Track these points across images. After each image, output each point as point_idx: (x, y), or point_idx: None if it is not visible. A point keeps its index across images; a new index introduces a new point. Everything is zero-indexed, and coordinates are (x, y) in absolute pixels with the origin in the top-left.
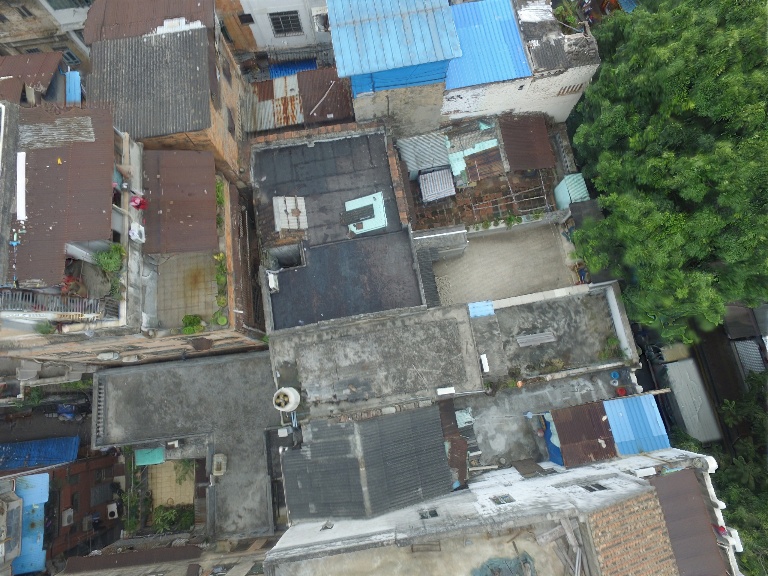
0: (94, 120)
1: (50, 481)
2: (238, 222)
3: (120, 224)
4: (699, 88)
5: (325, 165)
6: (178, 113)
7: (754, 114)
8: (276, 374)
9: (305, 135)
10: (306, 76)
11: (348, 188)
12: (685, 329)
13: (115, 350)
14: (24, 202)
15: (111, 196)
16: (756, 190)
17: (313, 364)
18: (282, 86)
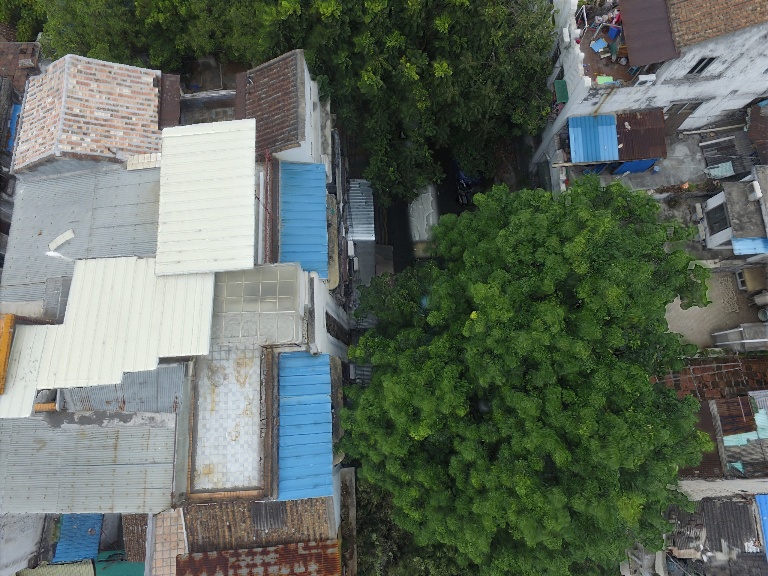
0: None
1: None
2: None
3: None
4: None
5: None
6: None
7: None
8: None
9: None
10: None
11: None
12: None
13: None
14: None
15: None
16: None
17: None
18: None
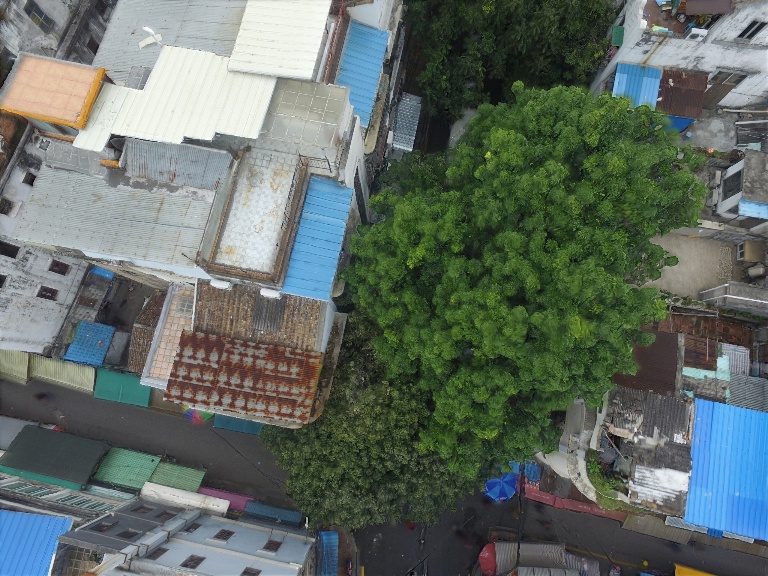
0: None
1: None
2: None
3: None
4: None
5: None
6: None
7: None
8: None
9: None
10: None
11: None
12: None
13: None
14: None
15: None
16: None
17: None
18: None
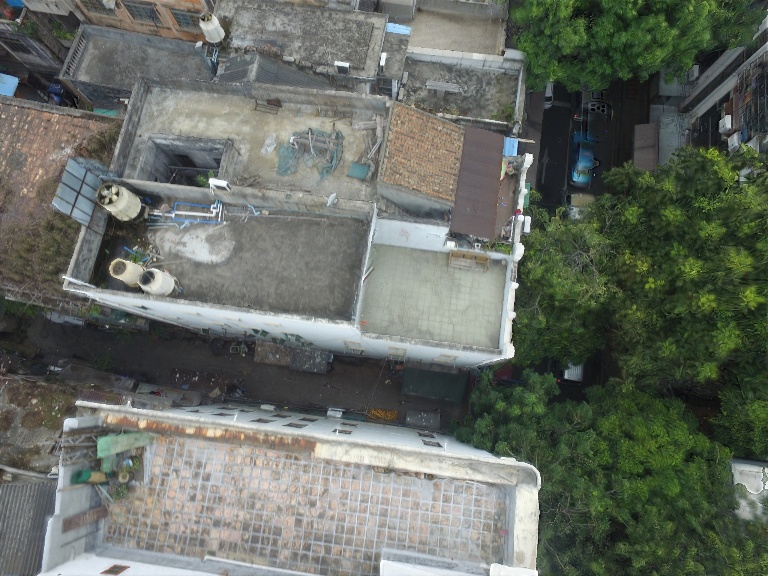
0: None
1: None
2: None
3: None
4: None
5: None
6: None
7: None
8: None
9: None
10: None
11: None
12: None
13: None
14: None
15: None
16: None
17: (246, 22)
18: None
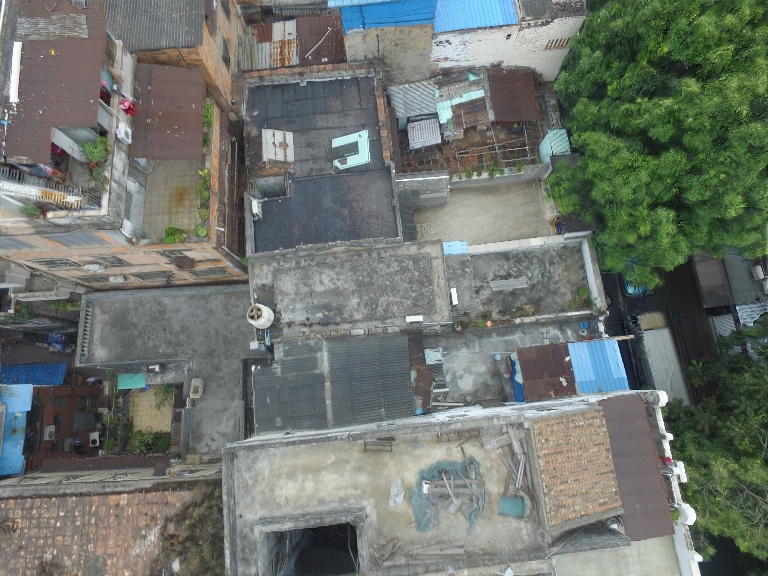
0: (88, 18)
1: (34, 396)
2: (226, 148)
3: (108, 122)
4: (673, 32)
5: (315, 103)
6: (172, 30)
7: (721, 55)
8: (253, 295)
9: (297, 72)
10: (305, 22)
11: (336, 126)
12: (665, 302)
13: (101, 263)
14: (17, 87)
15: (99, 88)
16: (719, 129)
17: (289, 288)
18: (281, 30)
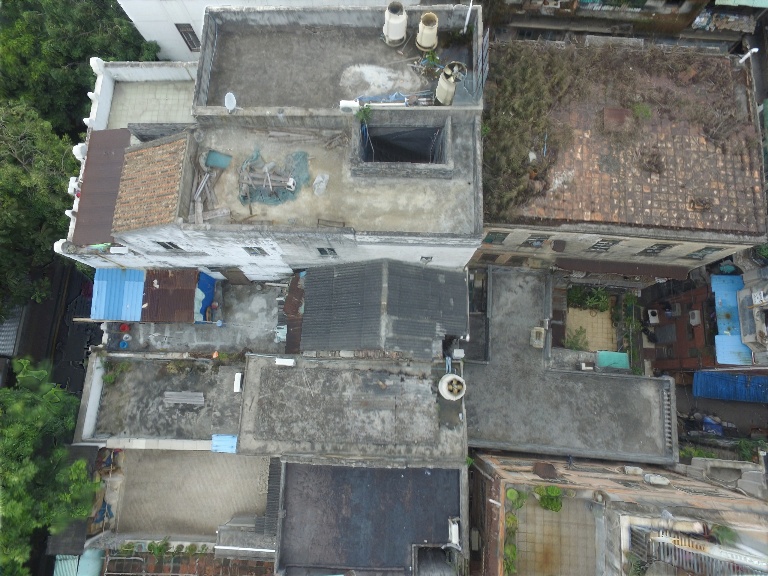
0: None
1: None
2: None
3: None
4: None
5: None
6: None
7: None
8: (463, 417)
9: None
10: None
11: None
12: (52, 378)
13: (649, 485)
14: None
15: None
16: None
17: (420, 420)
18: None
